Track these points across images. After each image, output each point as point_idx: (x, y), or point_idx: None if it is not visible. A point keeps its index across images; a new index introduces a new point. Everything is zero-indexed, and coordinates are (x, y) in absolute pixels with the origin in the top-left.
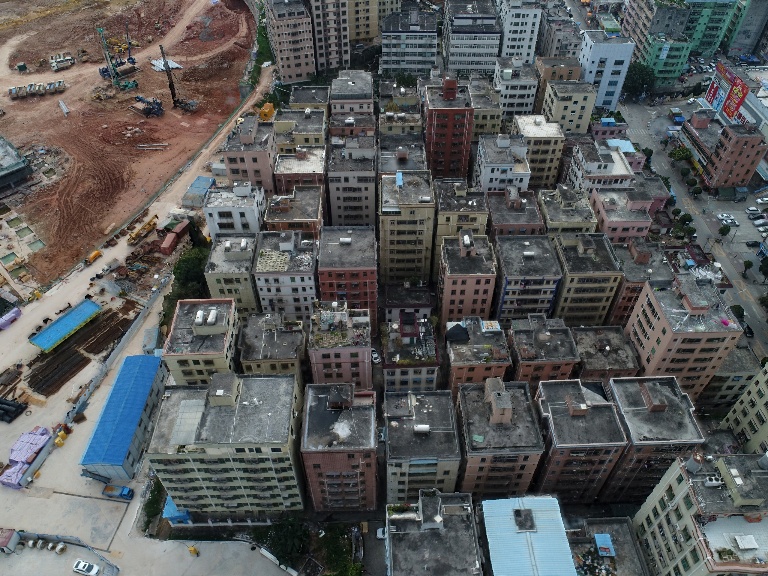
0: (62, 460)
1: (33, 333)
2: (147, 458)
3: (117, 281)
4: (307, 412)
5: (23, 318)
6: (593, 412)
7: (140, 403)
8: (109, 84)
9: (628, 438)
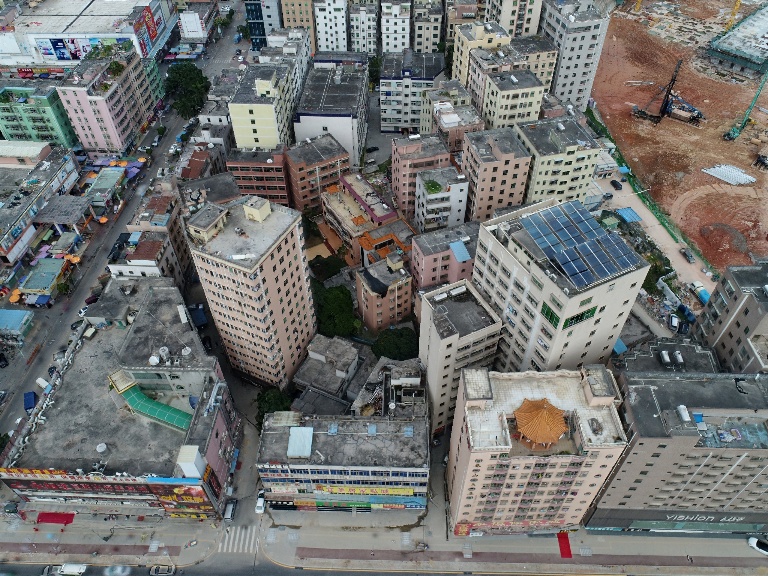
0: None
1: None
2: None
3: None
4: None
5: None
6: None
7: None
8: (759, 137)
9: None
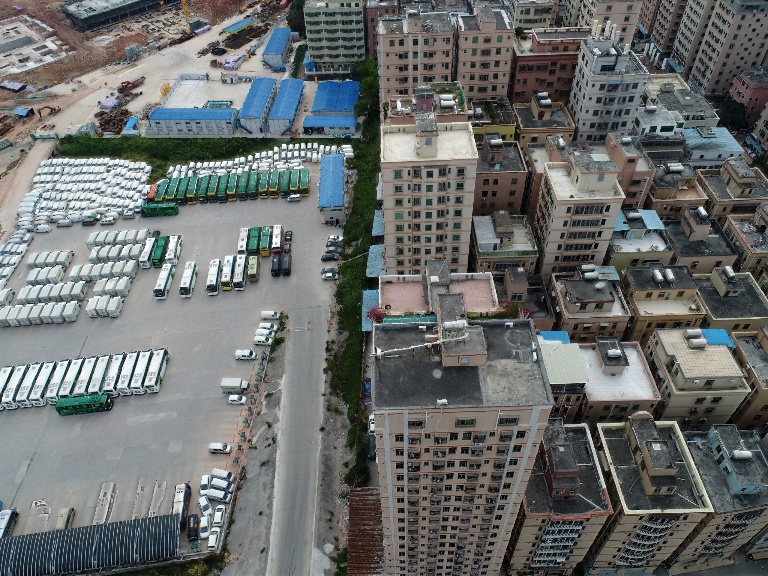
0: (249, 64)
1: (221, 32)
2: (304, 11)
3: (258, 17)
4: (368, 1)
5: (213, 30)
6: (491, 1)
7: (285, 40)
8: None
9: (503, 4)
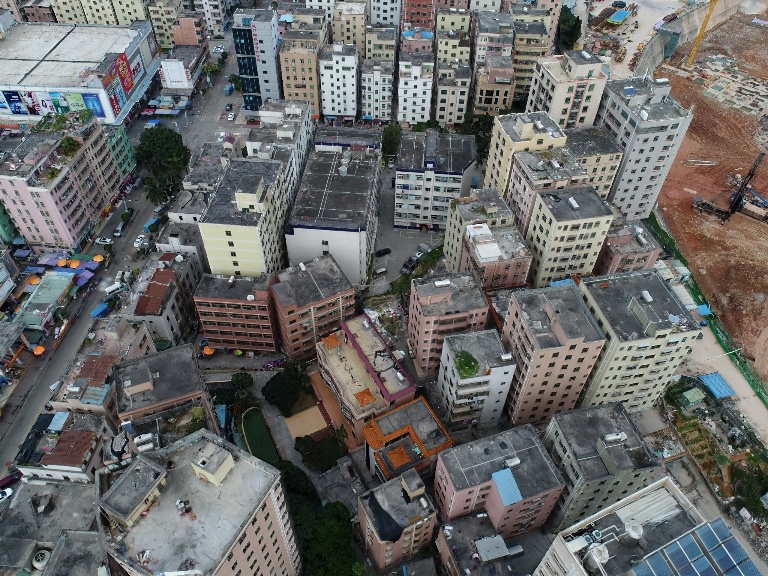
0: None
1: None
2: None
3: None
4: None
5: None
6: None
7: None
8: None
9: None
